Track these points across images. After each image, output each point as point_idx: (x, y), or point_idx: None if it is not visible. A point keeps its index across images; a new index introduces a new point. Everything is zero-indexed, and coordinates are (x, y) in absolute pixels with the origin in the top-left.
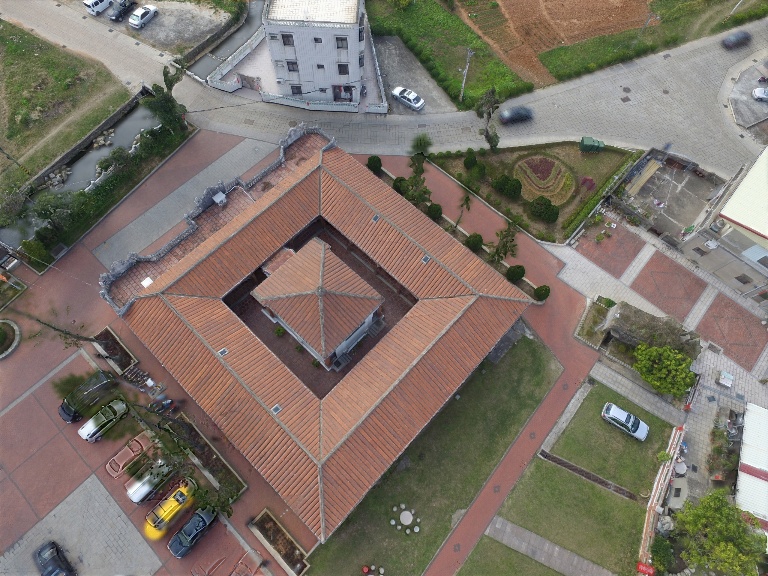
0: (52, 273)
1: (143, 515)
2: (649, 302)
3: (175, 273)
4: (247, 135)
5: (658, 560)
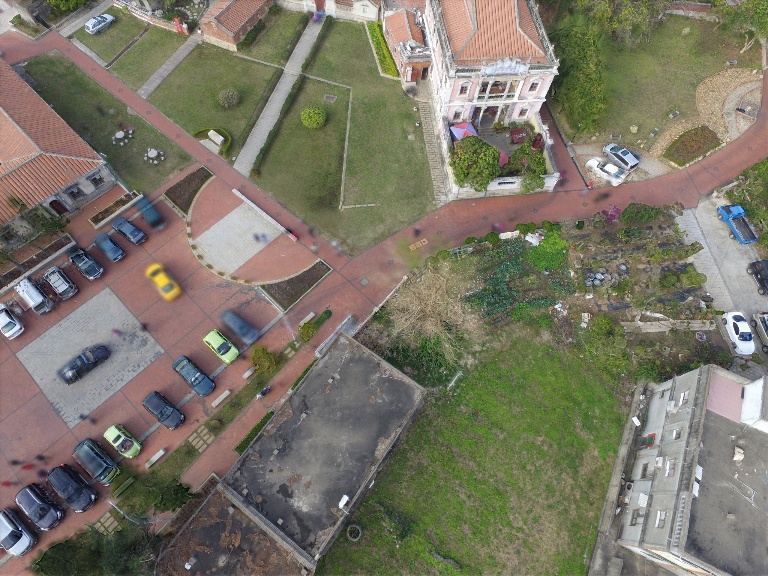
0: None
1: (65, 307)
2: None
3: None
4: None
5: None
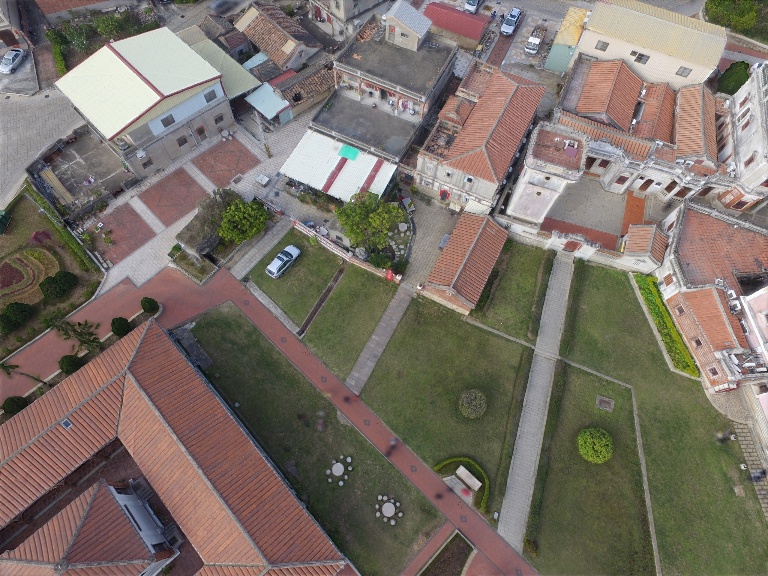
0: None
1: None
2: (185, 216)
3: None
4: None
5: (384, 264)
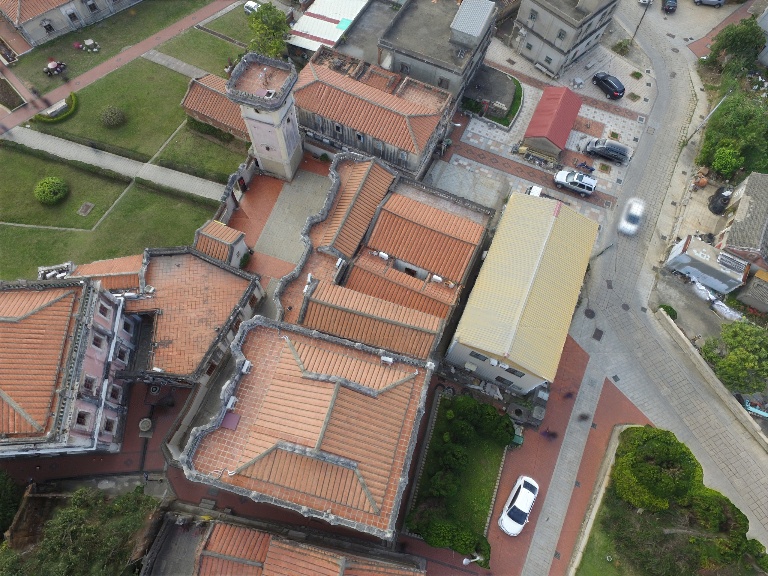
0: None
1: None
2: None
3: None
4: None
5: None
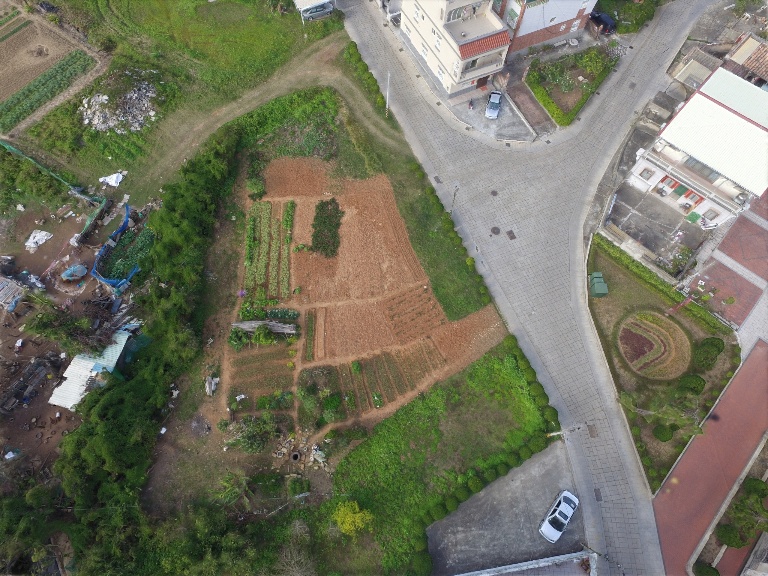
0: None
1: None
2: None
3: None
4: None
5: None
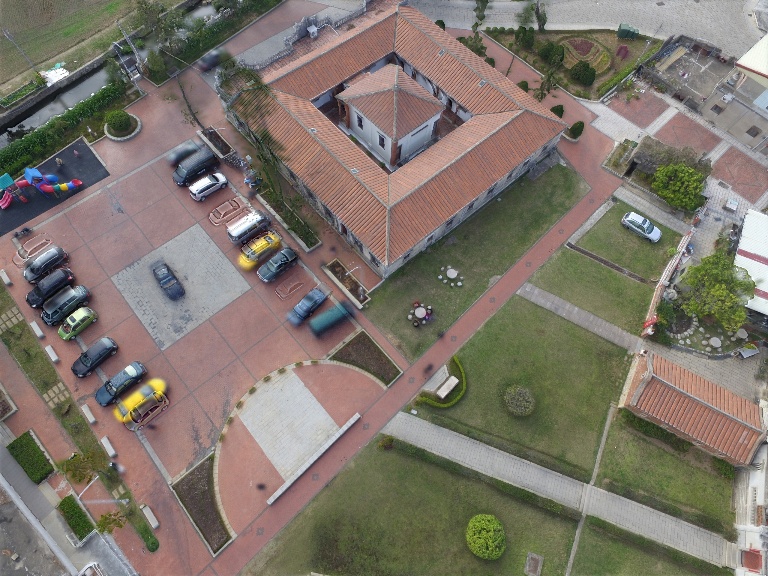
0: (167, 87)
1: (237, 254)
2: None
3: (275, 75)
4: (330, 4)
5: (662, 317)
